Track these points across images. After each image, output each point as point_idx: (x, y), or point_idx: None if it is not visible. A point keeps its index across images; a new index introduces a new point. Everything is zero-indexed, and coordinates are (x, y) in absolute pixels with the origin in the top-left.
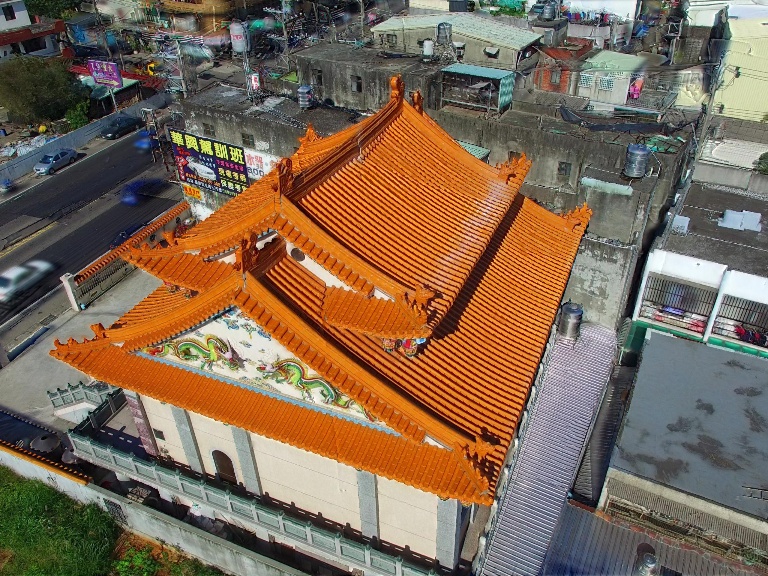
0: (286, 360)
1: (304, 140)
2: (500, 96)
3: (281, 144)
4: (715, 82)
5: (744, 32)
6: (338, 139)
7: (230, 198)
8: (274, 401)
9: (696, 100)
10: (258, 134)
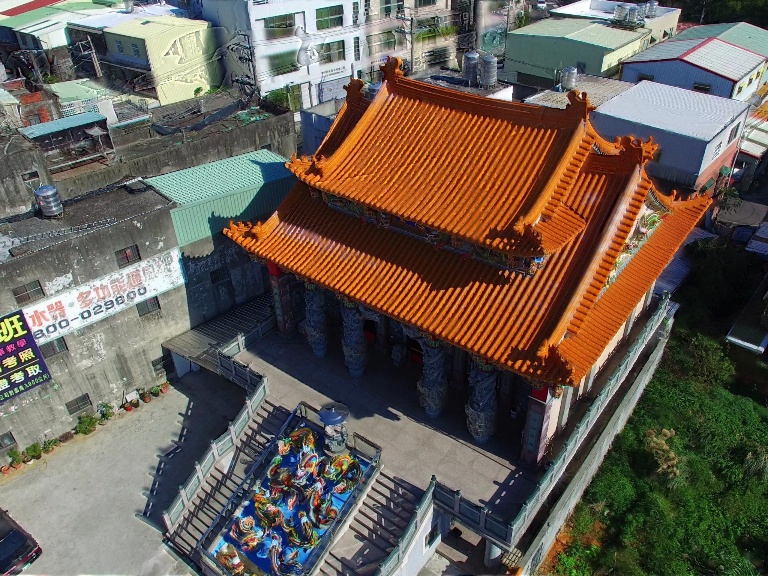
0: (644, 218)
1: (323, 163)
2: (110, 136)
3: (93, 261)
4: (253, 55)
5: (143, 33)
6: (350, 143)
7: (2, 406)
8: (630, 265)
9: (209, 84)
10: (48, 272)
